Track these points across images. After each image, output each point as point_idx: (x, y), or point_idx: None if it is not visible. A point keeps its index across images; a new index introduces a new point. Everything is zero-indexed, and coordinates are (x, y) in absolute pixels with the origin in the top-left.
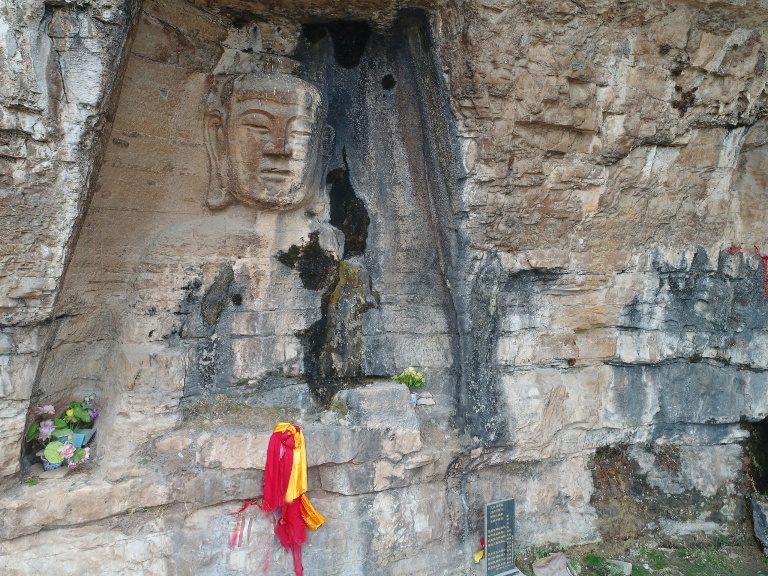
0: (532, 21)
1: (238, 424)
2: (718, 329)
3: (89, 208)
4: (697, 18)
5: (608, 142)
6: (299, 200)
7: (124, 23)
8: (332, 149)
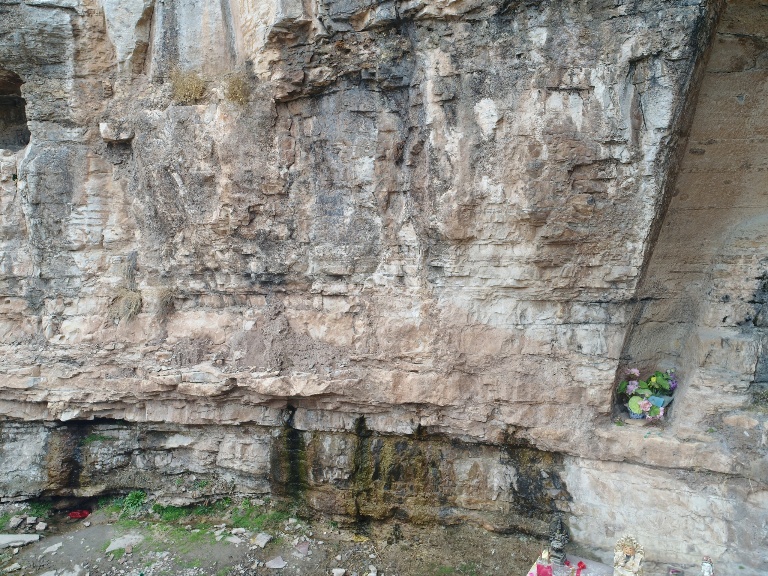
0: None
1: None
2: None
3: (669, 210)
4: None
5: None
6: None
7: (691, 55)
8: None
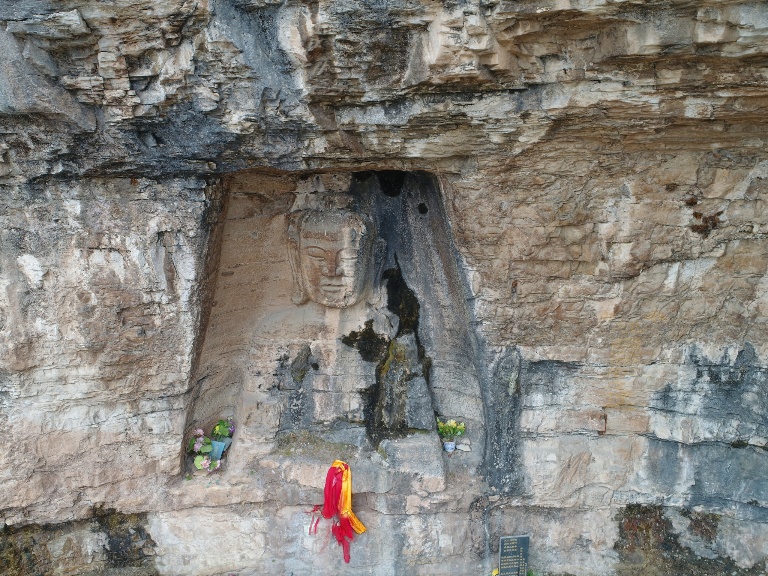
0: (509, 193)
1: (311, 455)
2: (767, 421)
3: (211, 316)
4: (705, 159)
5: (615, 266)
6: (352, 303)
7: (204, 233)
8: (384, 256)
